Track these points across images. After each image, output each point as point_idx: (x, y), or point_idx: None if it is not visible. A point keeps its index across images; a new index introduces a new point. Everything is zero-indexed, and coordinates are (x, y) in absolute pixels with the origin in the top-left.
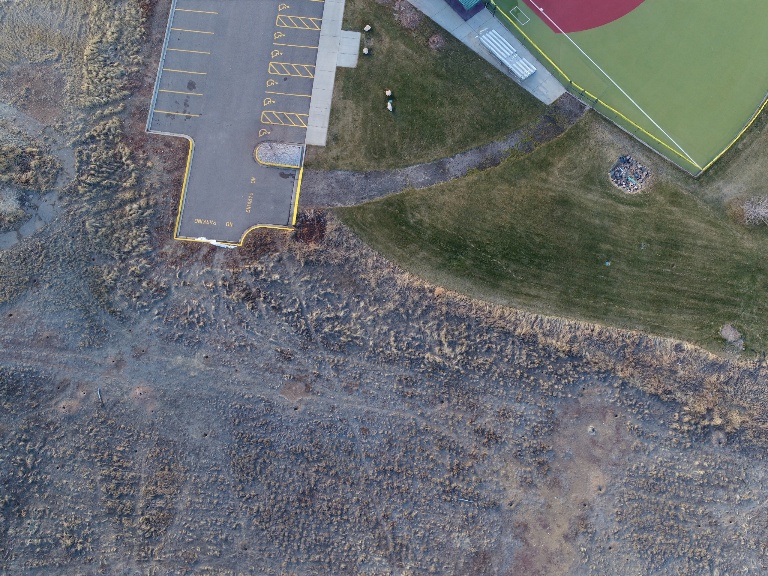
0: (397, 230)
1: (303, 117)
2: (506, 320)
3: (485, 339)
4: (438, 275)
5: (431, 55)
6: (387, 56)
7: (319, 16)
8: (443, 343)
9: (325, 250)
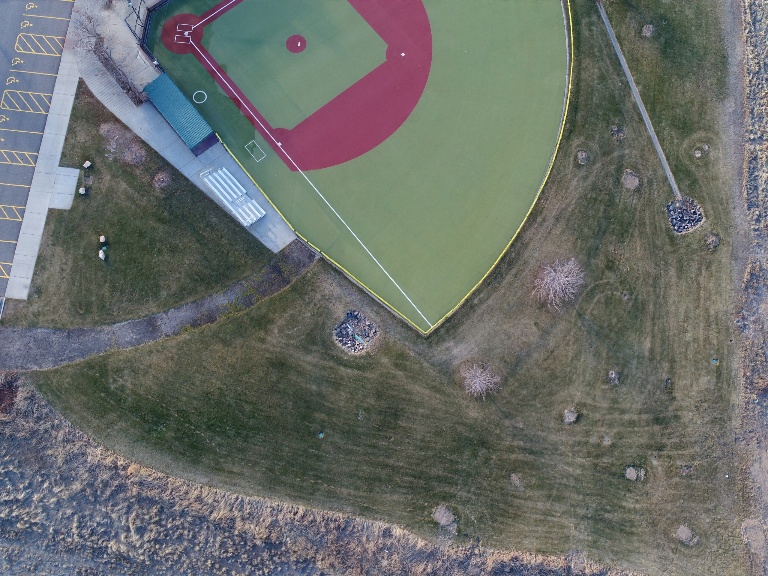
0: (95, 397)
1: (6, 266)
2: (203, 501)
3: (177, 524)
4: (135, 449)
5: (154, 195)
6: (106, 196)
7: (35, 150)
8: (130, 529)
9: (13, 421)
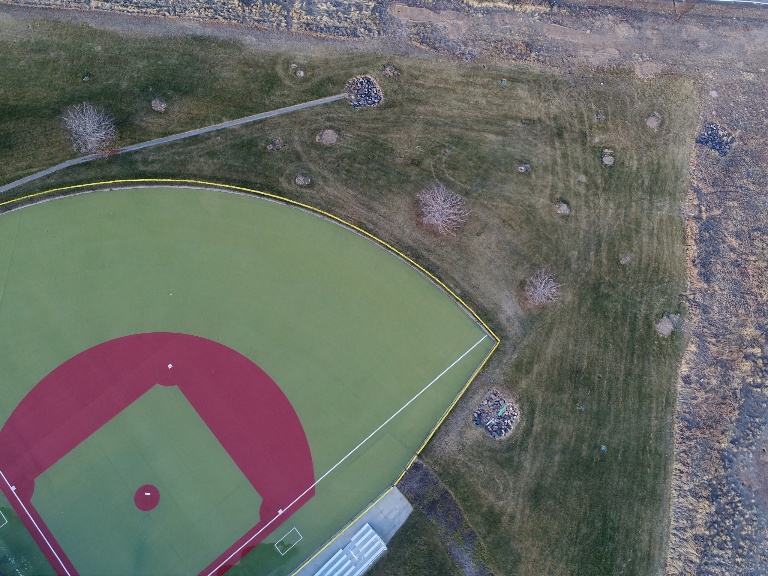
0: None
1: None
2: (681, 571)
3: None
4: None
5: None
6: None
7: None
8: None
9: None
